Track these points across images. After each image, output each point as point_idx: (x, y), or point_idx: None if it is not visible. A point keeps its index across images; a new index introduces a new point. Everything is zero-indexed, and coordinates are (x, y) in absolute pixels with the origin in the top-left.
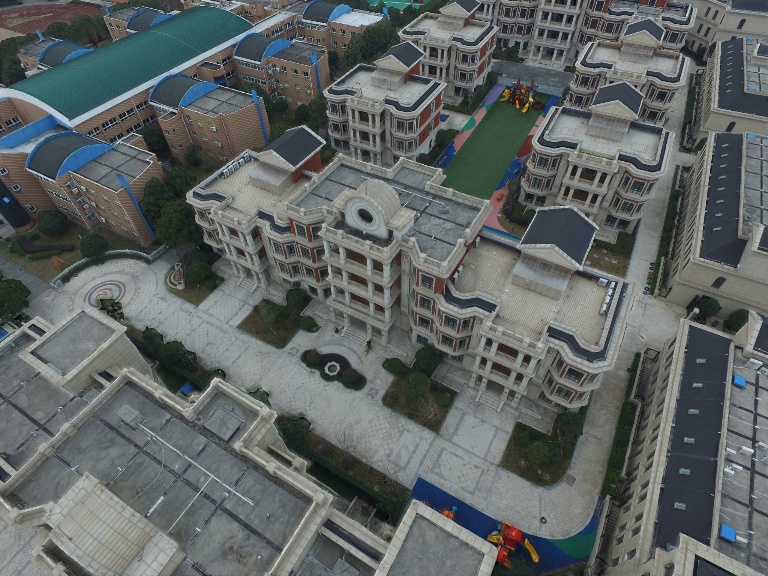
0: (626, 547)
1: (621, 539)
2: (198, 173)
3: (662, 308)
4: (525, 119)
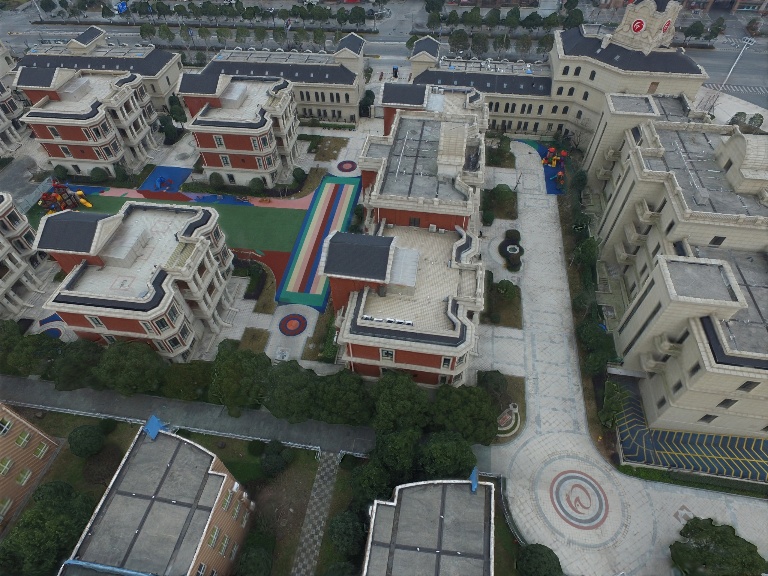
0: (535, 115)
1: (525, 125)
2: (283, 558)
3: (364, 125)
4: (108, 204)
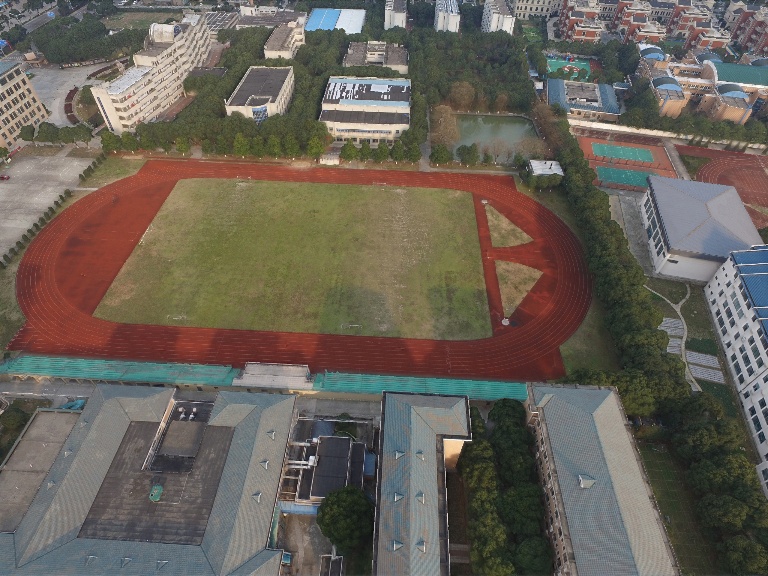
0: None
1: None
2: None
3: None
4: None
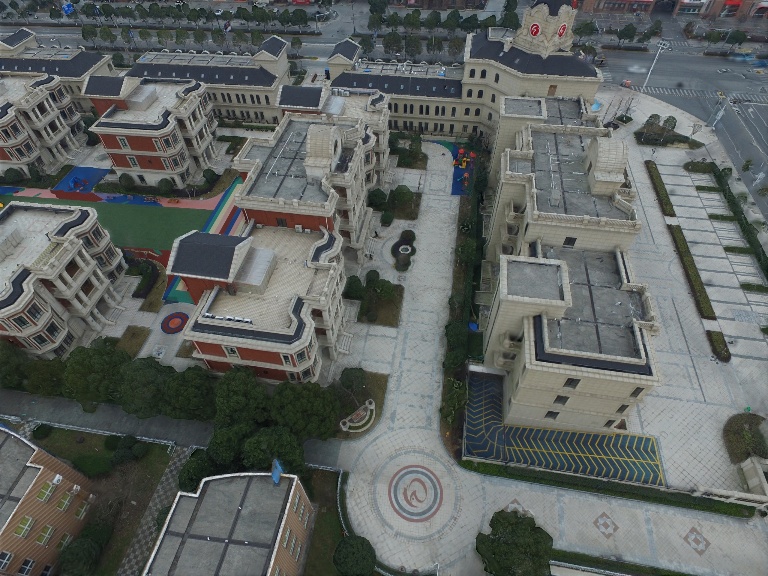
0: (449, 117)
1: (441, 127)
2: (117, 549)
3: None
4: None
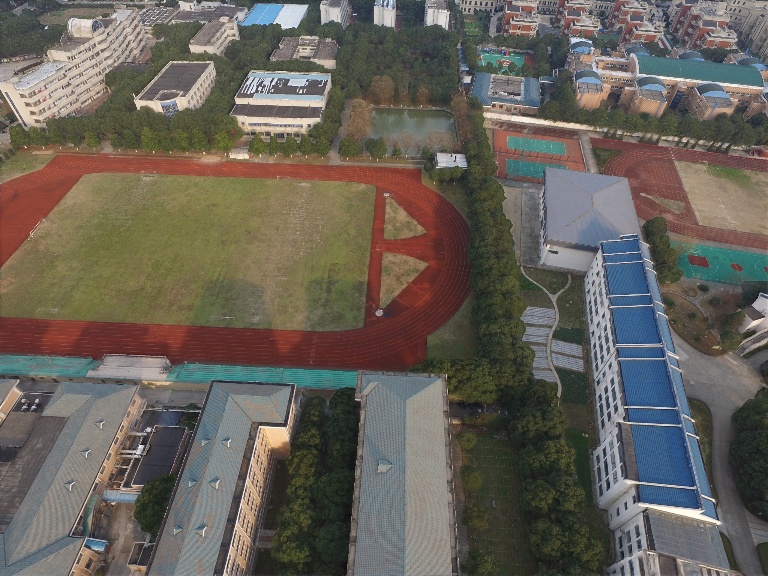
0: None
1: None
2: None
3: None
4: None
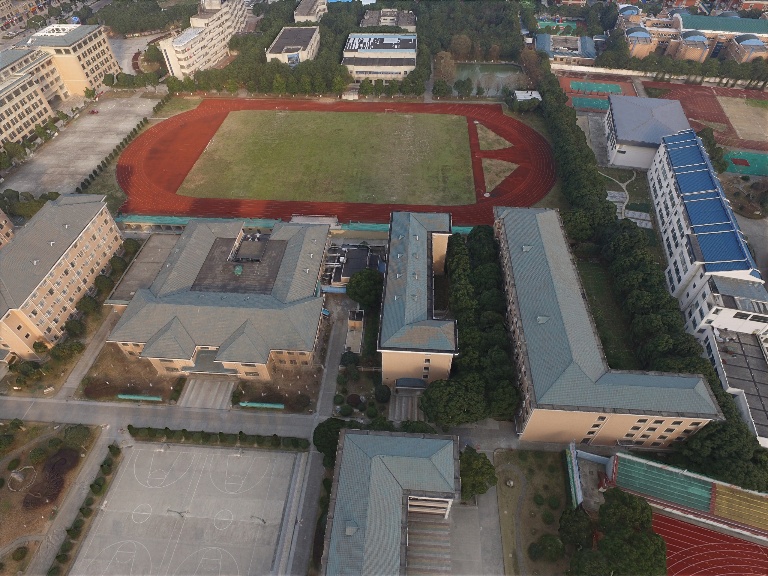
0: None
1: None
2: None
3: None
4: None
